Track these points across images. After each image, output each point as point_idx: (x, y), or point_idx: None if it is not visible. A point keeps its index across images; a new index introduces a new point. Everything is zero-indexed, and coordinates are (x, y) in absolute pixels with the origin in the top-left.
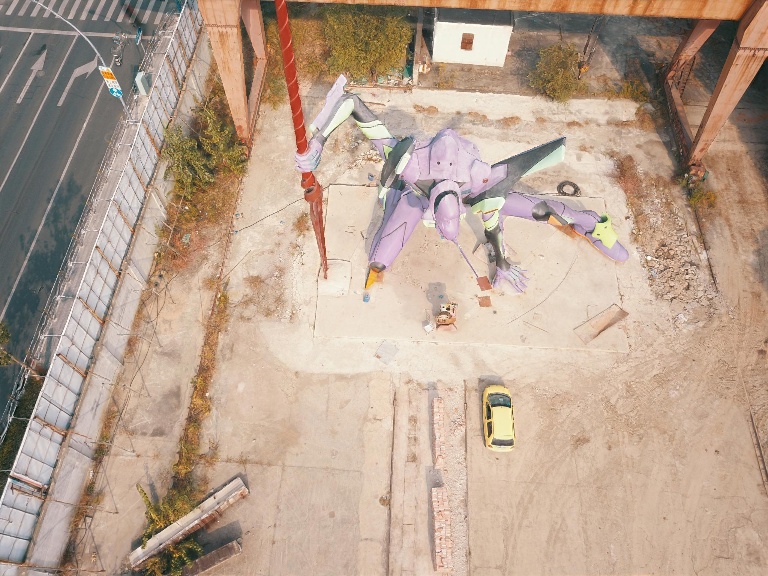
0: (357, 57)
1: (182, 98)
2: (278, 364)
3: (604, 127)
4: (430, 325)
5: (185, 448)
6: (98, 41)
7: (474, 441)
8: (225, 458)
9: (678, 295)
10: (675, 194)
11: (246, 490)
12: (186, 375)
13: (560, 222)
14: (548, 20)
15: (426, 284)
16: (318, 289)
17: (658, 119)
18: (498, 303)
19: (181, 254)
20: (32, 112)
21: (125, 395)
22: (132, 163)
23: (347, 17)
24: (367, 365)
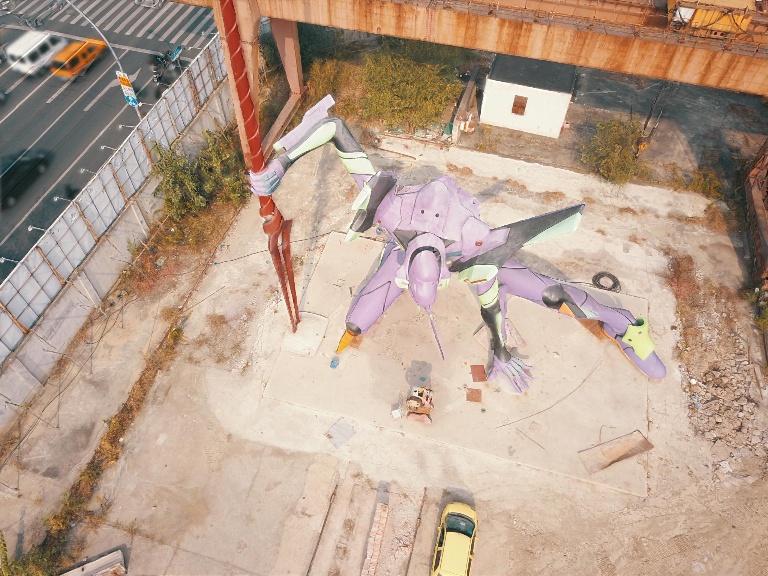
0: (391, 102)
1: (198, 117)
2: (212, 420)
3: (663, 219)
4: (399, 410)
5: (72, 499)
6: (145, 57)
7: (418, 571)
8: (114, 522)
9: (725, 436)
10: (740, 310)
11: (122, 568)
12: (107, 412)
13: (574, 313)
14: (619, 99)
15: (409, 361)
16: (283, 342)
17: (731, 220)
18: (490, 400)
19: (148, 276)
20: (57, 113)
21: (33, 421)
22: (112, 168)
23: (387, 59)
24: (313, 443)
